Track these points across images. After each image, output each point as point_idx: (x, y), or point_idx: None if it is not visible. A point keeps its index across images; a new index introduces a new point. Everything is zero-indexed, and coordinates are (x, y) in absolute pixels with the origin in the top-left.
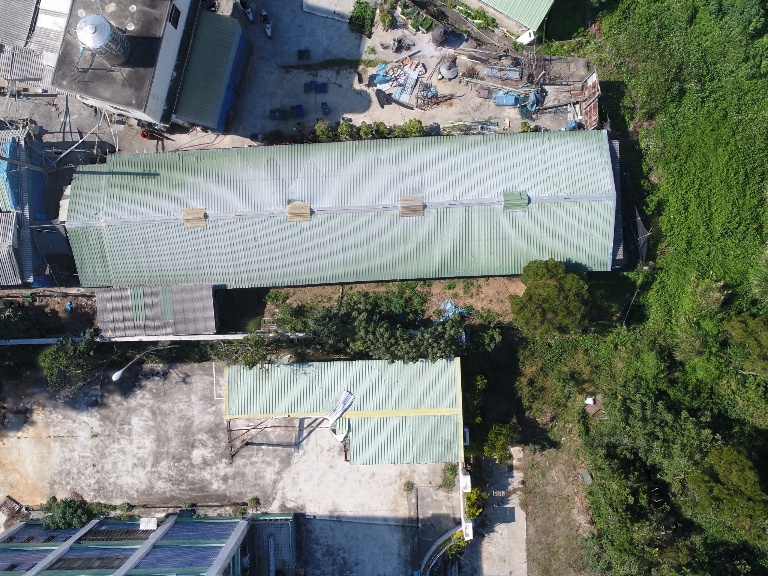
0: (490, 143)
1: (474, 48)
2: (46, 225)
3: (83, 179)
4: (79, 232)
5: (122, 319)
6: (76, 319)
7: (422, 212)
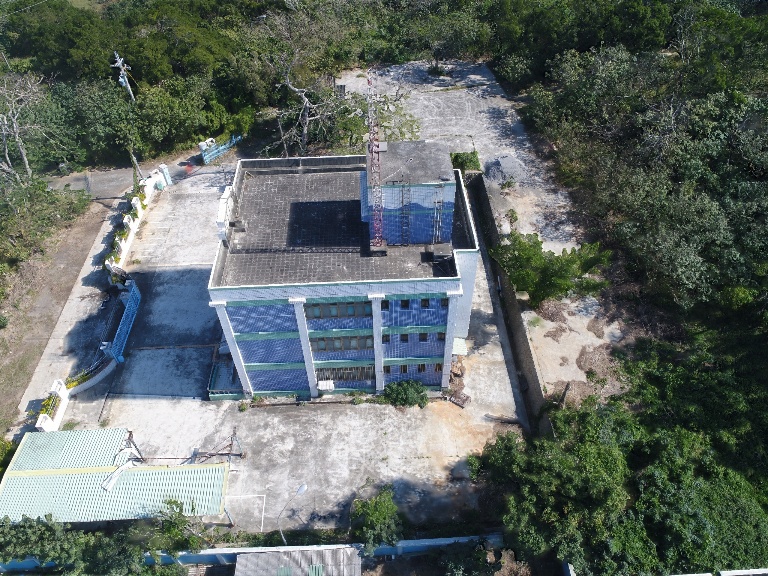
0: None
1: None
2: None
3: None
4: None
5: (334, 568)
6: (400, 575)
7: None
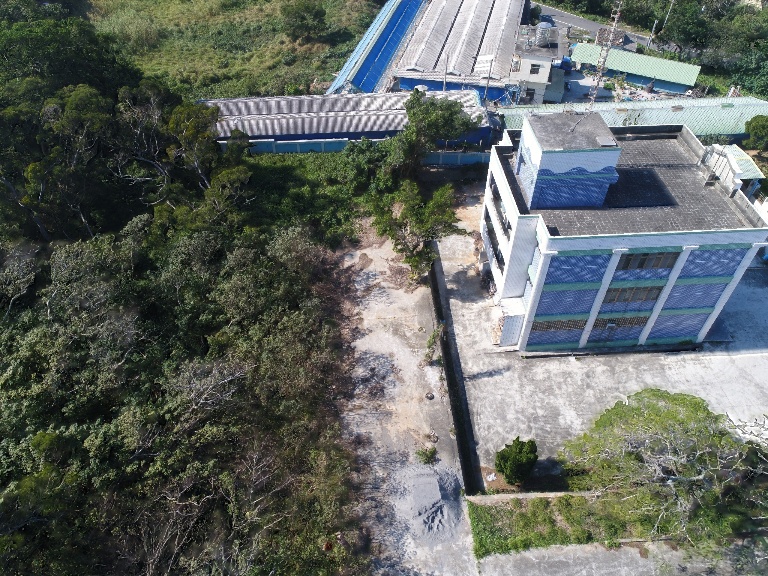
0: (699, 99)
1: (667, 93)
2: (495, 113)
3: (503, 109)
4: (511, 117)
5: None
6: None
7: (682, 110)
